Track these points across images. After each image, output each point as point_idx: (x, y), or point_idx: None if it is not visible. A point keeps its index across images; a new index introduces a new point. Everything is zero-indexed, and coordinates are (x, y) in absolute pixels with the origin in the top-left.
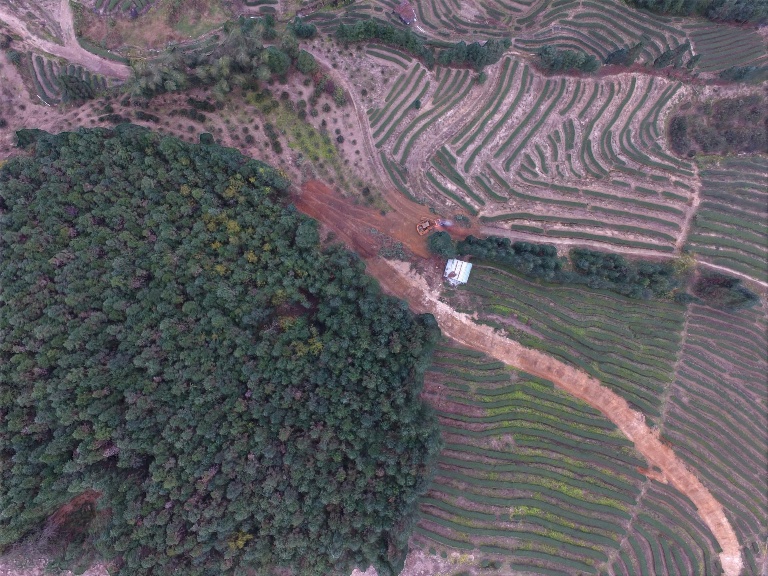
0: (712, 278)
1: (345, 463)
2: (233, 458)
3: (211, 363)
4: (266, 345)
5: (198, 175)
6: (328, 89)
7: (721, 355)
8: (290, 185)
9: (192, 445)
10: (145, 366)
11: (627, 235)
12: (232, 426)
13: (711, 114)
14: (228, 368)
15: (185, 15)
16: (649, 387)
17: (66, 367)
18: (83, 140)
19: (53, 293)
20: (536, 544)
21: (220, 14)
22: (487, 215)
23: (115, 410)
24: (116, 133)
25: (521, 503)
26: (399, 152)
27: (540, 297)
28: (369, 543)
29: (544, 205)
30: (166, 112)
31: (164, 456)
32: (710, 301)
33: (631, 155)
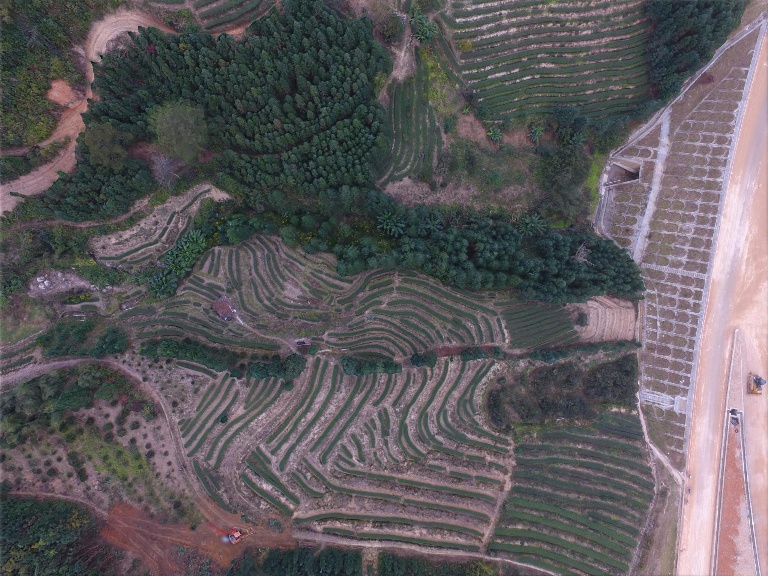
0: None
1: None
2: None
3: None
4: None
5: None
6: (134, 410)
7: None
8: (96, 510)
9: None
10: None
11: (435, 535)
12: None
13: (529, 381)
14: None
15: (4, 322)
16: None
17: None
18: None
19: None
20: None
21: (40, 316)
22: (301, 516)
23: None
24: None
25: None
26: (213, 456)
27: None
28: None
29: (359, 499)
30: None
31: None
32: None
33: (448, 435)
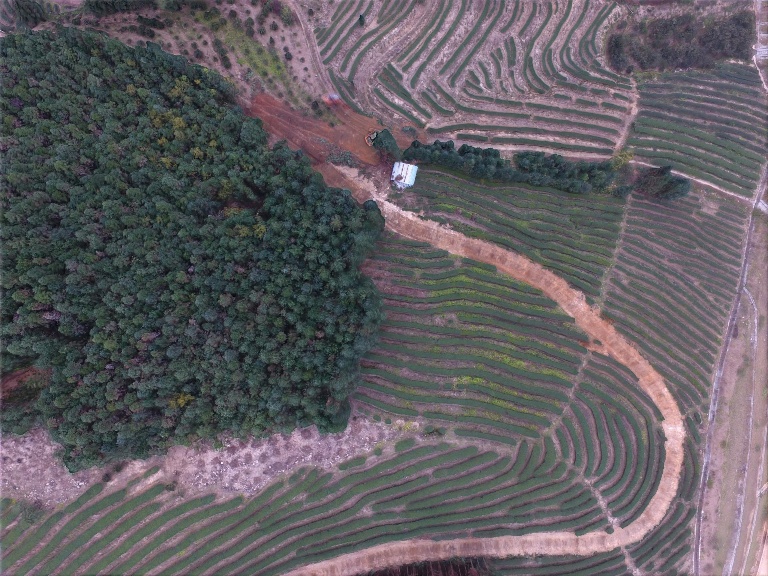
0: (648, 172)
1: (287, 330)
2: (174, 323)
3: (155, 242)
4: (210, 227)
5: (144, 76)
6: (274, 7)
7: (659, 243)
8: (240, 98)
9: (133, 310)
10: (87, 240)
11: (568, 140)
12: (173, 293)
13: (647, 34)
14: (172, 246)
15: None
16: (589, 270)
17: (7, 238)
18: (29, 40)
19: None
20: (480, 411)
21: None
22: (434, 127)
23: (56, 277)
24: (62, 35)
25: (464, 372)
26: (347, 70)
27: (484, 196)
28: (309, 397)
29: (489, 117)
30: (116, 29)
31: (105, 319)
32: None
33: (572, 71)
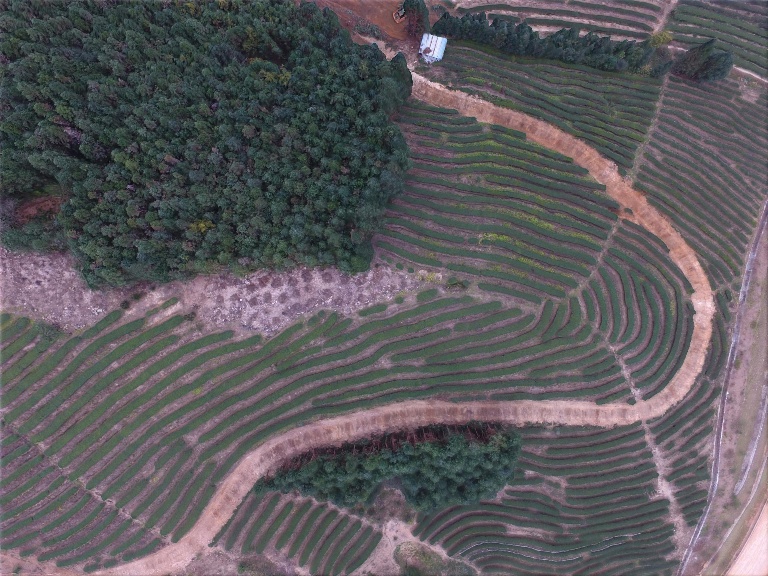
0: (688, 53)
1: (311, 168)
2: (197, 150)
3: (178, 78)
4: (234, 68)
5: None
6: None
7: (696, 124)
8: None
9: (156, 134)
10: (110, 66)
11: (604, 23)
12: None
13: None
14: None
15: None
16: (622, 144)
17: None
18: None
19: None
20: (505, 267)
21: None
22: (464, 7)
23: (78, 96)
24: None
25: (490, 229)
26: None
27: (515, 72)
28: (332, 228)
29: None
30: None
31: (127, 140)
32: None
33: None
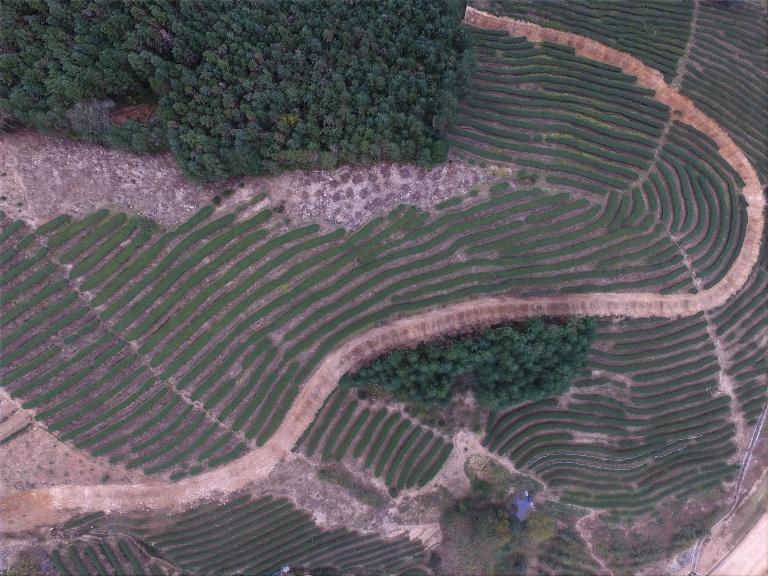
0: None
1: None
2: (281, 52)
3: None
4: None
5: None
6: None
7: (730, 40)
8: None
9: (242, 38)
10: None
11: None
12: None
13: None
14: None
15: None
16: (665, 57)
17: None
18: None
19: None
20: (569, 162)
21: None
22: None
23: (169, 4)
24: None
25: (553, 128)
26: None
27: (556, 1)
28: (414, 116)
29: None
30: None
31: (217, 42)
32: None
33: None
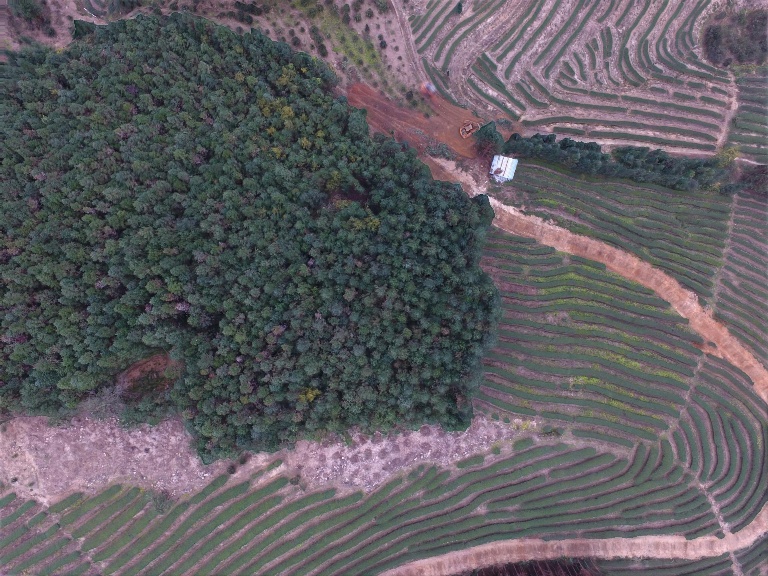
0: (756, 170)
1: (409, 325)
2: (301, 316)
3: (273, 233)
4: (325, 219)
5: (251, 64)
6: None
7: None
8: (335, 88)
9: (260, 303)
10: (211, 230)
11: (669, 135)
12: (298, 286)
13: (745, 25)
14: (290, 239)
15: None
16: (700, 270)
17: (135, 227)
18: (141, 25)
19: (119, 162)
20: (597, 412)
21: None
22: (528, 119)
23: (185, 268)
24: (172, 20)
25: (581, 372)
26: (440, 59)
27: (586, 191)
28: (438, 395)
29: (584, 110)
30: (214, 15)
31: (234, 311)
32: (755, 192)
33: (668, 63)
